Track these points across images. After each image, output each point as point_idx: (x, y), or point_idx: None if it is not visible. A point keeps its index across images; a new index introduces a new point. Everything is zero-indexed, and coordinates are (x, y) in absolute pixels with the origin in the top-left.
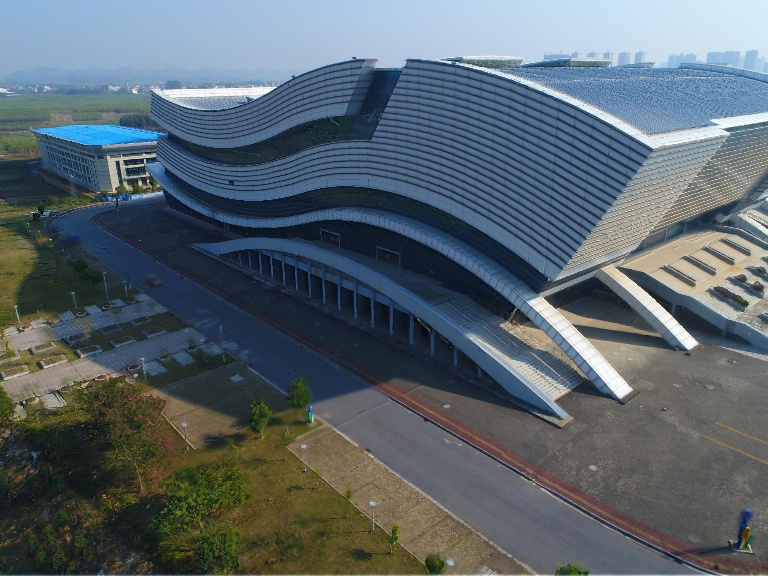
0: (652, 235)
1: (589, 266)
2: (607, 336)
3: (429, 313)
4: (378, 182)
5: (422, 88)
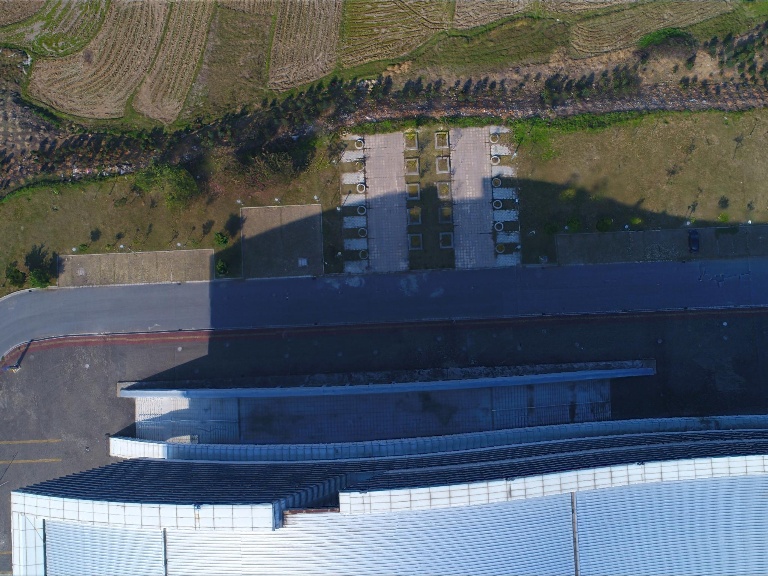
0: None
1: None
2: None
3: None
4: (341, 460)
5: None
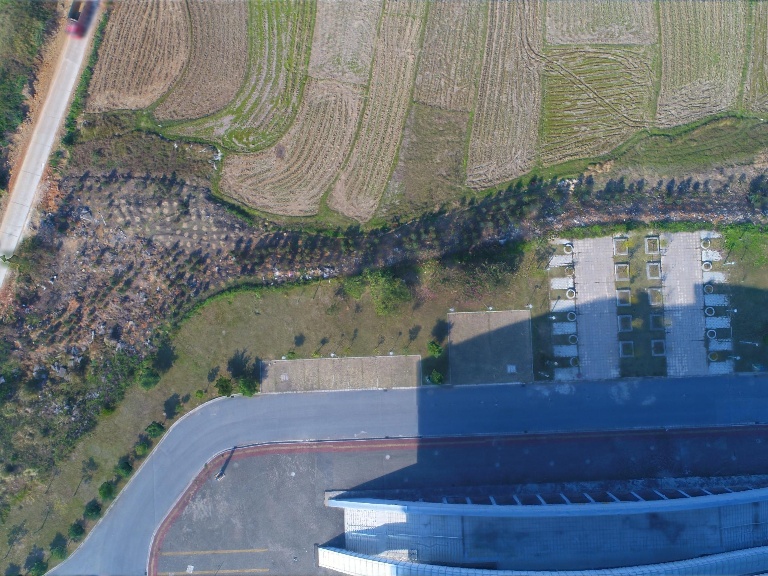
0: None
1: None
2: None
3: None
4: None
5: None
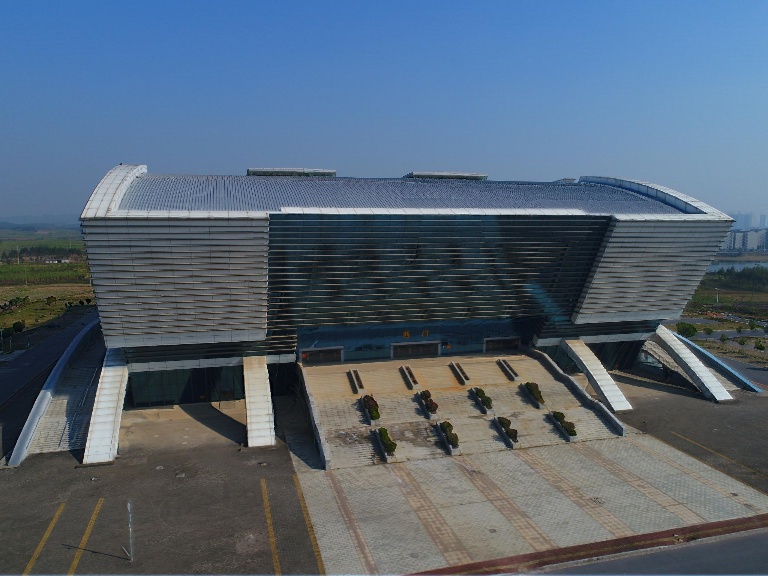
0: (405, 345)
1: (170, 342)
2: (219, 424)
3: None
4: None
5: None
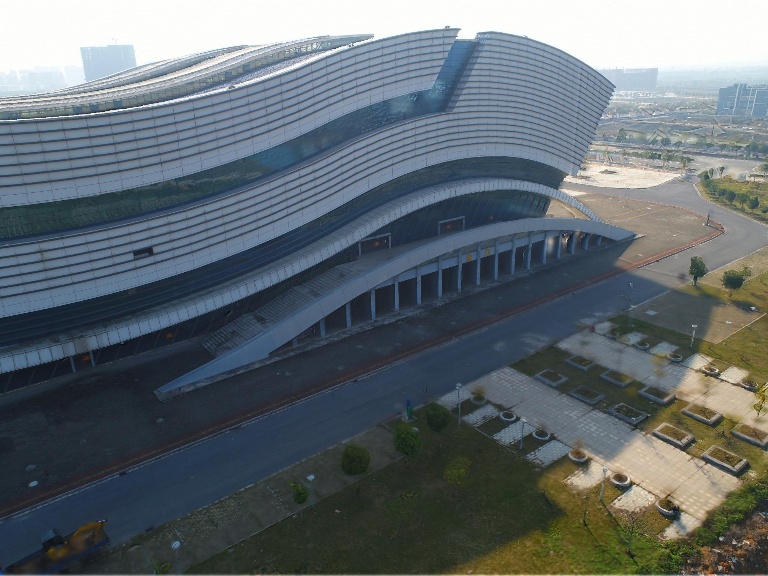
0: None
1: None
2: None
3: (578, 222)
4: (460, 152)
5: (503, 57)
